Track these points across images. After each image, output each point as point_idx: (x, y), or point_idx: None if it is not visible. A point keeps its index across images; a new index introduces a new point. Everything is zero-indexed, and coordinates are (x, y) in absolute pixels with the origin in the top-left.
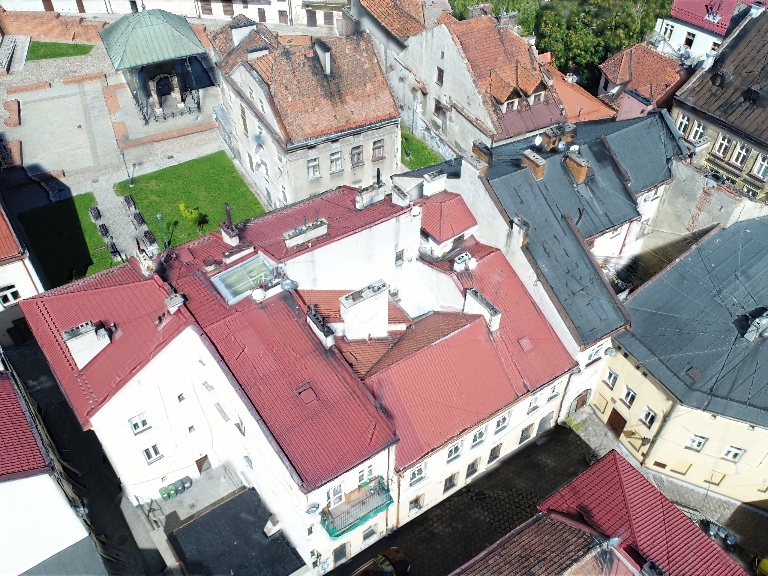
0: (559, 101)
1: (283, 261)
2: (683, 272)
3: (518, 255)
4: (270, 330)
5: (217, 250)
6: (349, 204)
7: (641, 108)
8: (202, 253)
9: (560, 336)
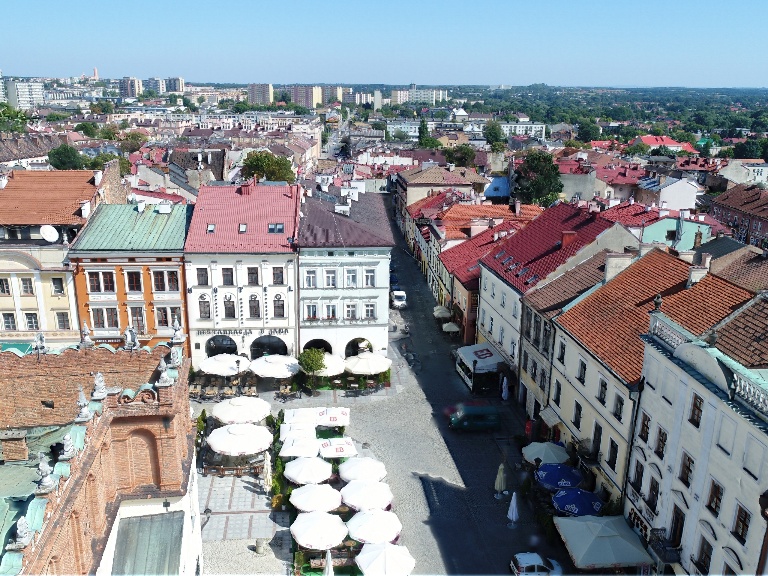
0: None
1: None
2: None
3: (170, 184)
4: None
5: None
6: None
7: (166, 164)
8: None
9: (194, 201)
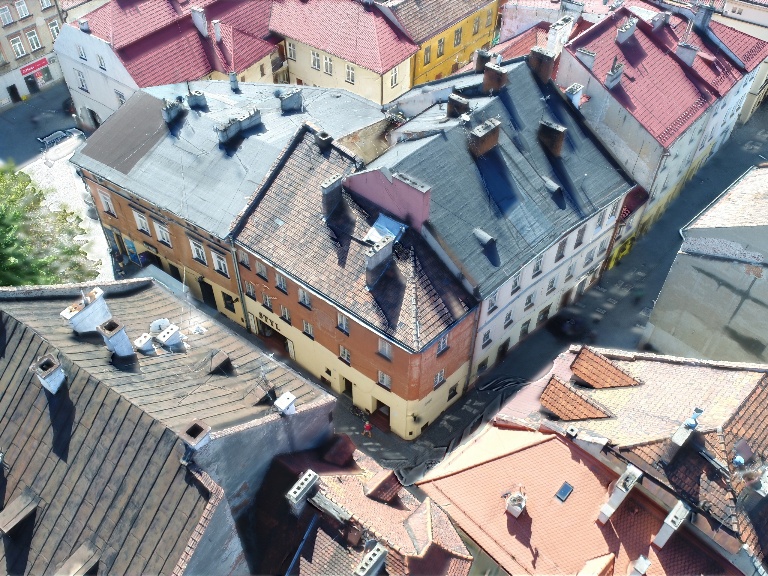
0: (515, 419)
1: (621, 6)
2: (345, 131)
3: None
4: (600, 7)
5: None
6: (633, 99)
7: None
8: None
9: None
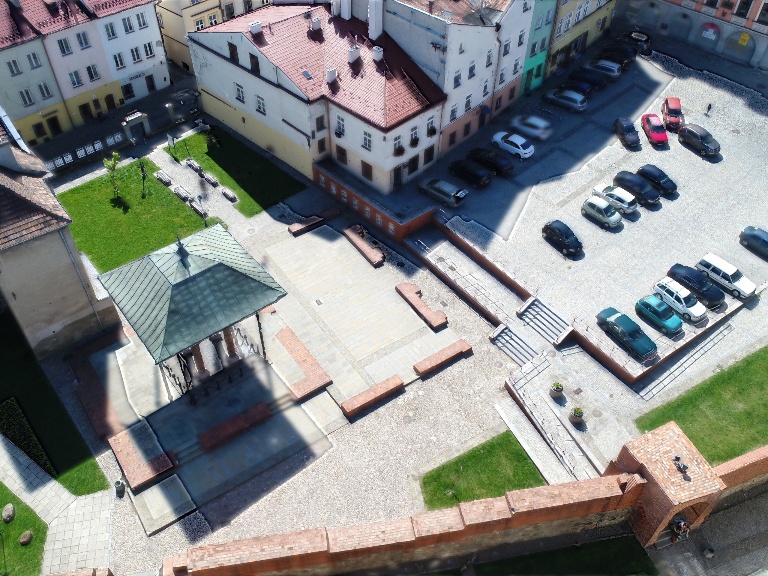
0: None
1: None
2: None
3: None
4: None
5: (26, 2)
6: None
7: None
8: (38, 3)
9: None
